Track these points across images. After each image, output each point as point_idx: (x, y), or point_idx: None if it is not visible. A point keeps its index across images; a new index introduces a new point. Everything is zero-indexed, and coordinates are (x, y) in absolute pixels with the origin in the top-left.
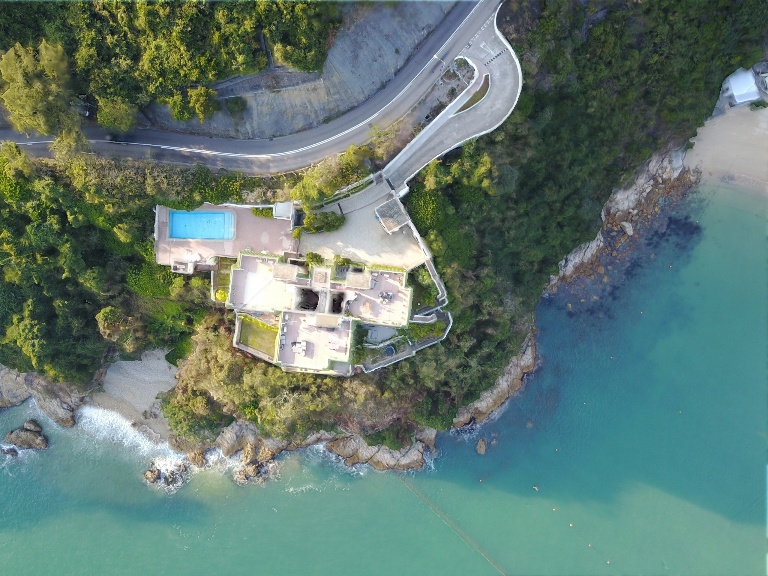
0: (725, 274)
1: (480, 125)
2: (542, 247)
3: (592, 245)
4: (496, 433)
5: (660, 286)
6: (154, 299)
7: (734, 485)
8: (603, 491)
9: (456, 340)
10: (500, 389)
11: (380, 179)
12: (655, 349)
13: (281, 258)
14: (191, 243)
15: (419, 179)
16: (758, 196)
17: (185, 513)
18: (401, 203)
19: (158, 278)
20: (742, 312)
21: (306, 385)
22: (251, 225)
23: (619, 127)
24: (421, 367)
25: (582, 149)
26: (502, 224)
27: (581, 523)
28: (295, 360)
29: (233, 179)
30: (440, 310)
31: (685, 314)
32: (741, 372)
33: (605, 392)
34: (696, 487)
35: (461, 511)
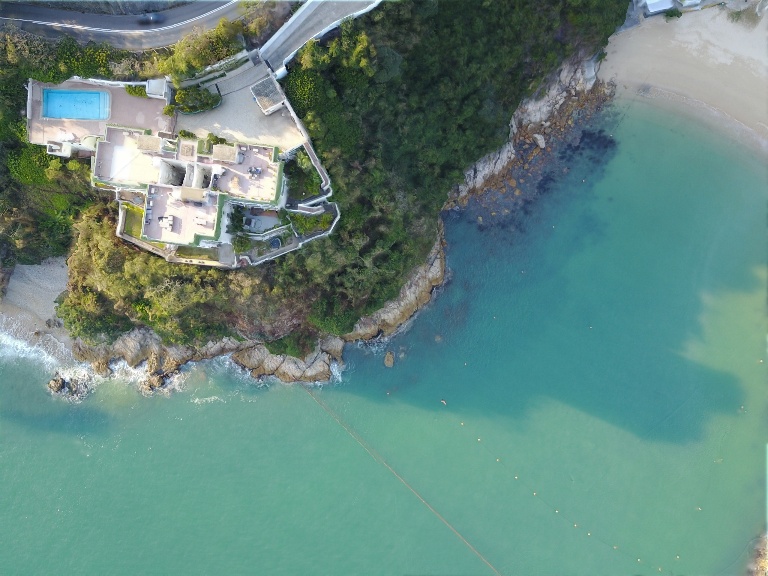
0: (639, 189)
1: (358, 3)
2: (443, 150)
3: (502, 156)
4: (405, 347)
5: (573, 201)
6: (41, 191)
7: (644, 401)
8: (512, 406)
9: (348, 236)
10: (408, 301)
11: (258, 60)
12: (567, 265)
13: (148, 131)
14: (65, 122)
15: (297, 60)
16: (673, 110)
17: (90, 424)
18: (277, 82)
19: (34, 160)
20: (655, 228)
21: (190, 275)
22: (126, 105)
23: (521, 27)
24: (307, 259)
25: (479, 45)
26: (395, 119)
27: (490, 438)
28: (162, 235)
29: (100, 50)
30: (327, 202)
31: (598, 229)
32: (653, 288)
33: (516, 307)
34: (605, 403)
35: (368, 424)
